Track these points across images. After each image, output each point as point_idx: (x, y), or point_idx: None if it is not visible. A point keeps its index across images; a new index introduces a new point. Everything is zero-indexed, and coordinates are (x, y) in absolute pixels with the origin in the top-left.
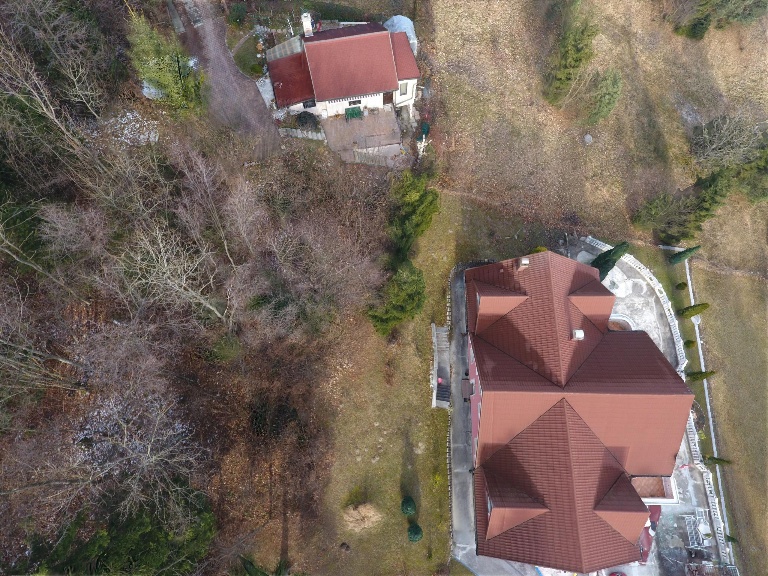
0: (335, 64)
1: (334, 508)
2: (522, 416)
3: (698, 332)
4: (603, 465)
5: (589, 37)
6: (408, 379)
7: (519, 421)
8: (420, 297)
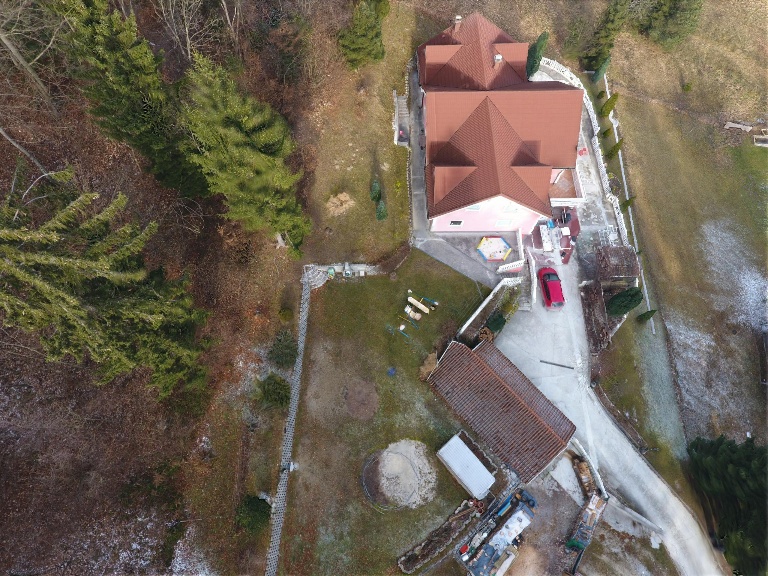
0: None
1: (319, 202)
2: (458, 115)
3: None
4: (520, 149)
5: None
6: (374, 118)
7: (456, 119)
8: (378, 35)
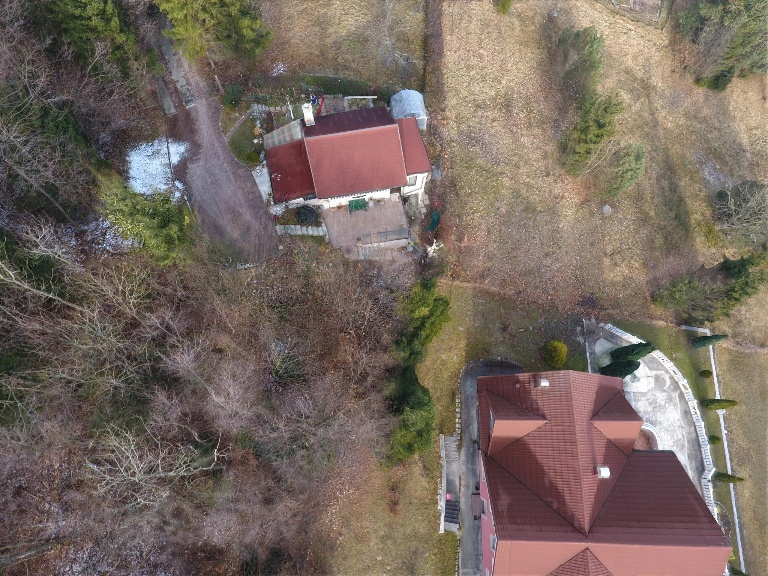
0: (338, 160)
1: None
2: (541, 565)
3: (723, 424)
4: None
5: (612, 114)
6: (414, 504)
7: (537, 569)
8: (429, 429)
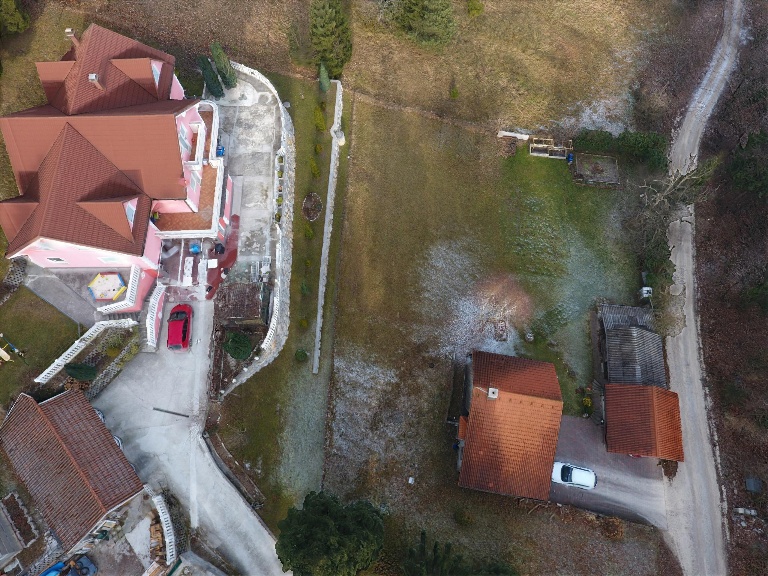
0: None
1: None
2: (40, 142)
3: None
4: (109, 180)
5: None
6: None
7: (39, 147)
8: None
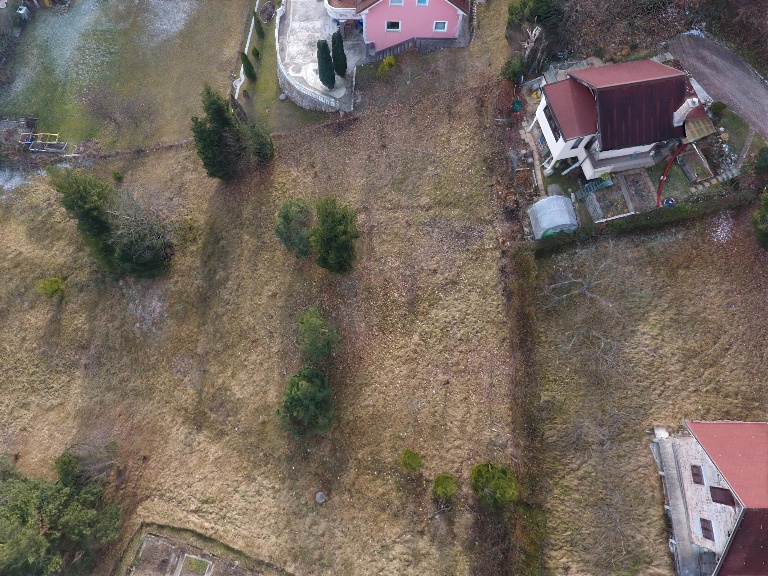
0: None
1: None
2: None
3: None
4: None
5: None
6: None
7: None
8: None
